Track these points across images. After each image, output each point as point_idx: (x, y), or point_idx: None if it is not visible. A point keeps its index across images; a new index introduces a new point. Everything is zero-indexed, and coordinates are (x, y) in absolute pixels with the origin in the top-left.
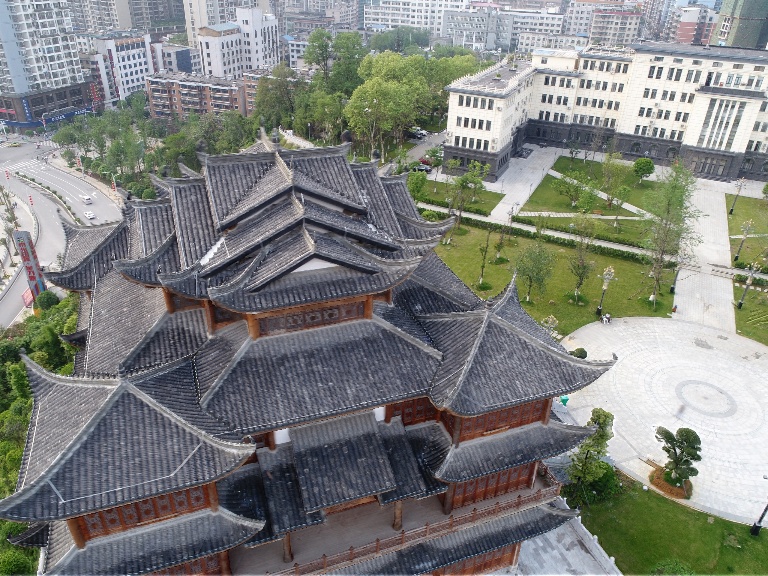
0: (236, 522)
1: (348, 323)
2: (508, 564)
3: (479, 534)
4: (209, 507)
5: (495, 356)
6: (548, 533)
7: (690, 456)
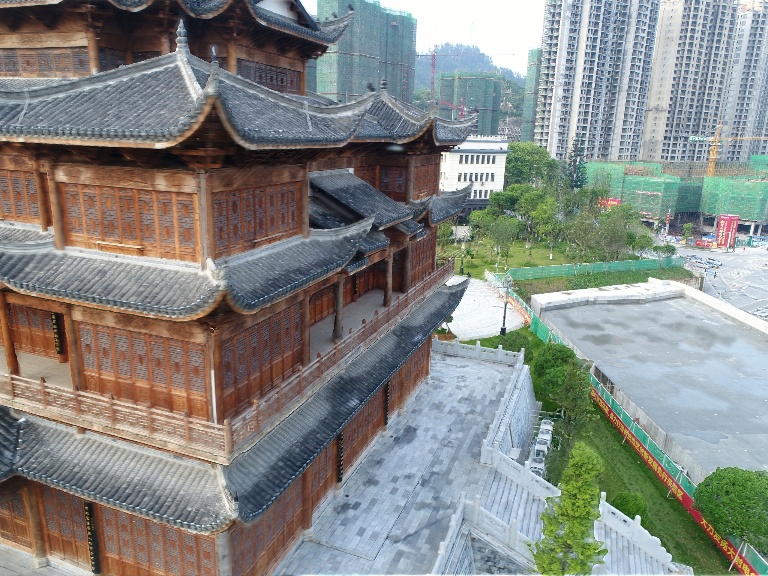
0: (336, 239)
1: (293, 95)
2: (425, 375)
3: (427, 314)
4: (299, 234)
5: None
6: None
7: None
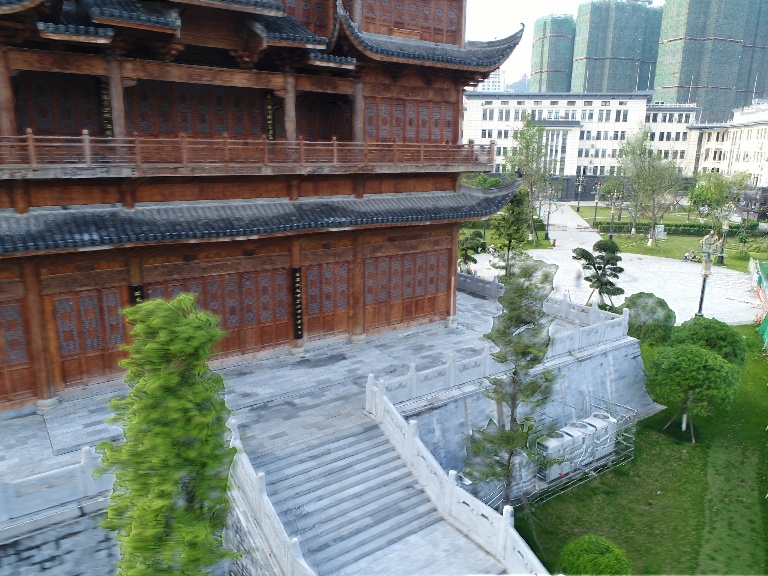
0: None
1: None
2: (445, 315)
3: (404, 207)
4: None
5: None
6: (485, 308)
7: (612, 275)
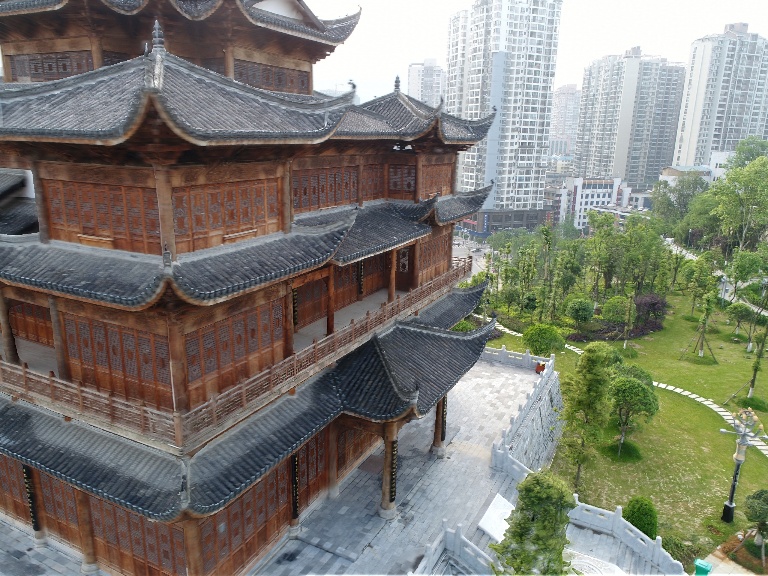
0: None
1: None
2: None
3: (85, 452)
4: None
5: (98, 92)
6: None
7: None
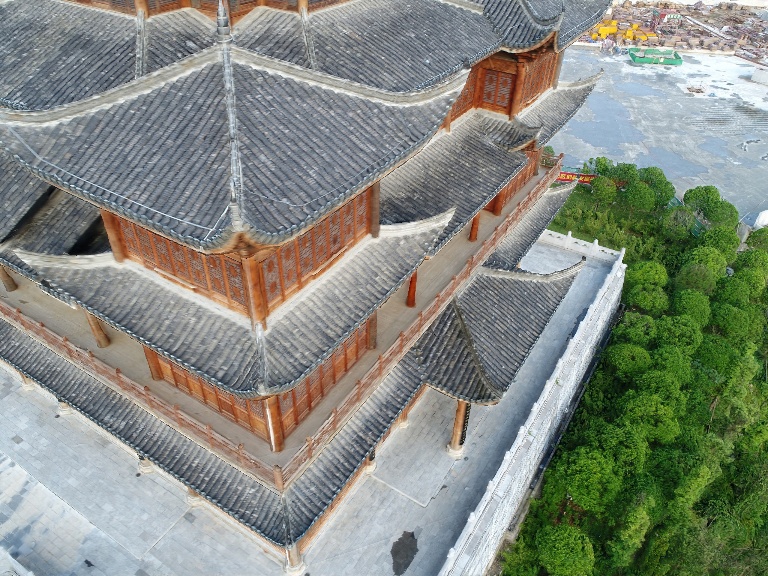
0: None
1: None
2: None
3: None
4: None
5: None
6: None
7: None
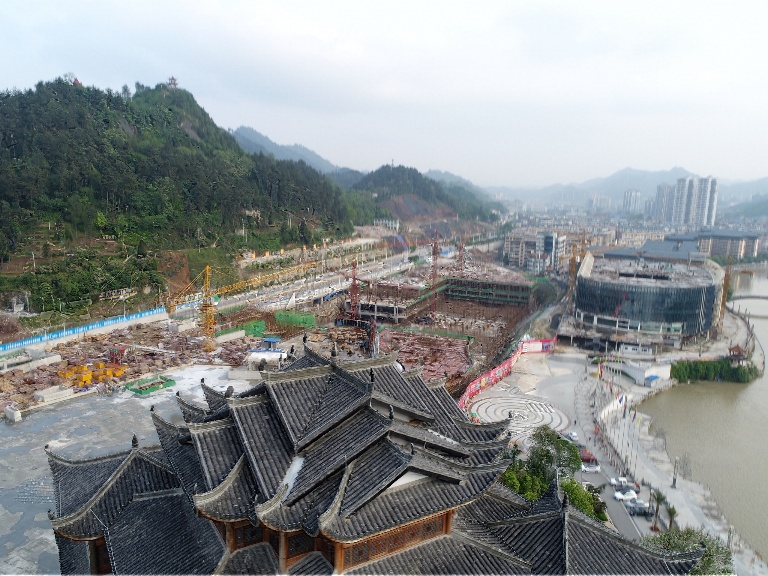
0: None
1: None
2: None
3: None
4: None
5: None
6: None
7: None
